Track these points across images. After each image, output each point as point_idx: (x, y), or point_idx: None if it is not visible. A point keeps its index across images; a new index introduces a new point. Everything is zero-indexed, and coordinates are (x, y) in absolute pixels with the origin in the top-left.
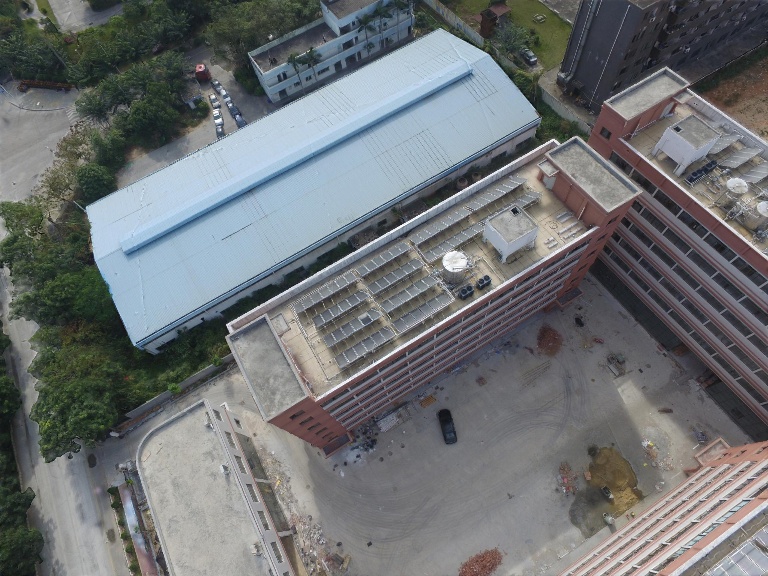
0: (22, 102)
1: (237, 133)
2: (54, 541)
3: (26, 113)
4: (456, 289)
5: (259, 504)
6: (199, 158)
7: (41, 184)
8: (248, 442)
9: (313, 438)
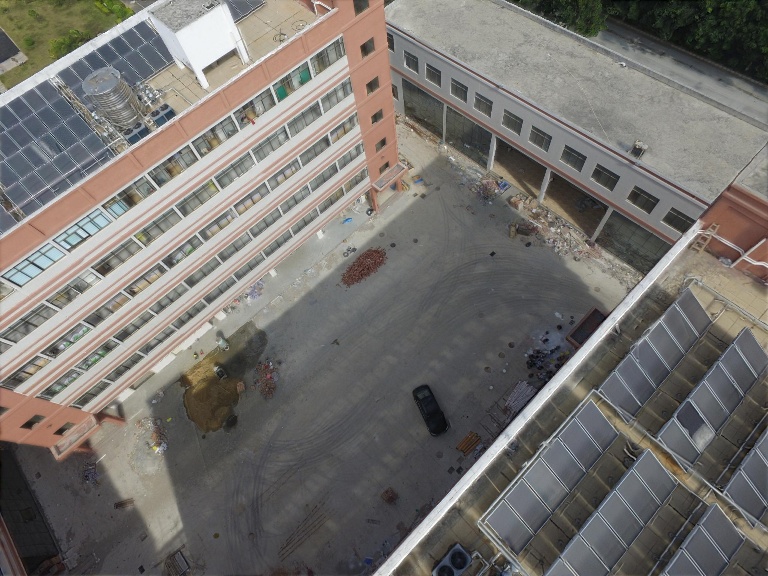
0: None
1: None
2: None
3: None
4: (482, 574)
5: (661, 216)
6: None
7: None
8: None
9: None
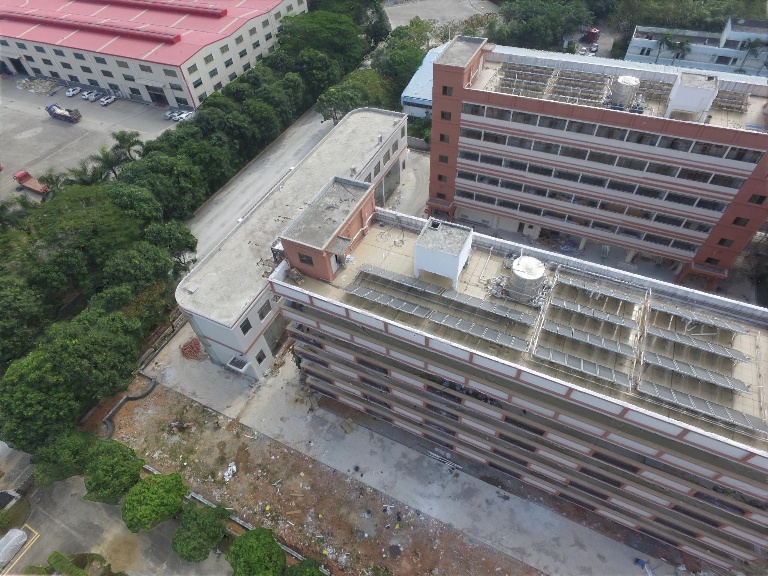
0: (476, 3)
1: (576, 55)
2: (277, 152)
3: (471, 8)
4: None
5: None
6: (537, 52)
7: (442, 26)
8: (396, 184)
9: (435, 161)
